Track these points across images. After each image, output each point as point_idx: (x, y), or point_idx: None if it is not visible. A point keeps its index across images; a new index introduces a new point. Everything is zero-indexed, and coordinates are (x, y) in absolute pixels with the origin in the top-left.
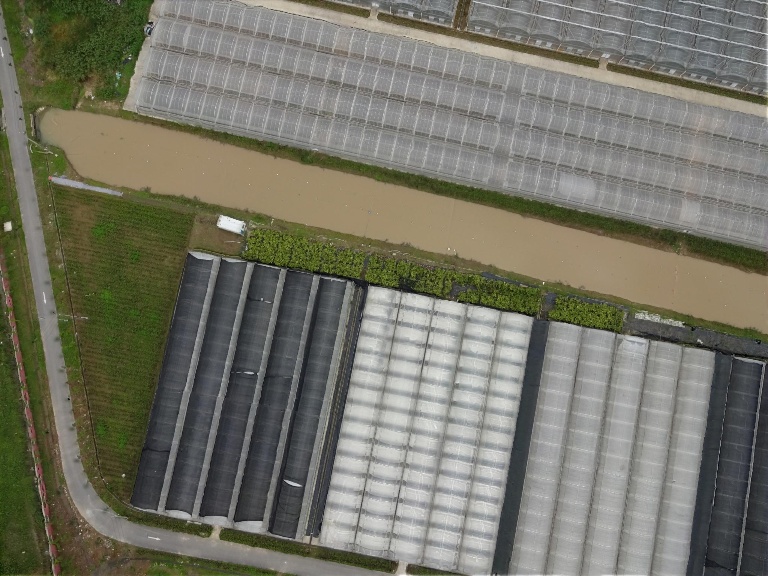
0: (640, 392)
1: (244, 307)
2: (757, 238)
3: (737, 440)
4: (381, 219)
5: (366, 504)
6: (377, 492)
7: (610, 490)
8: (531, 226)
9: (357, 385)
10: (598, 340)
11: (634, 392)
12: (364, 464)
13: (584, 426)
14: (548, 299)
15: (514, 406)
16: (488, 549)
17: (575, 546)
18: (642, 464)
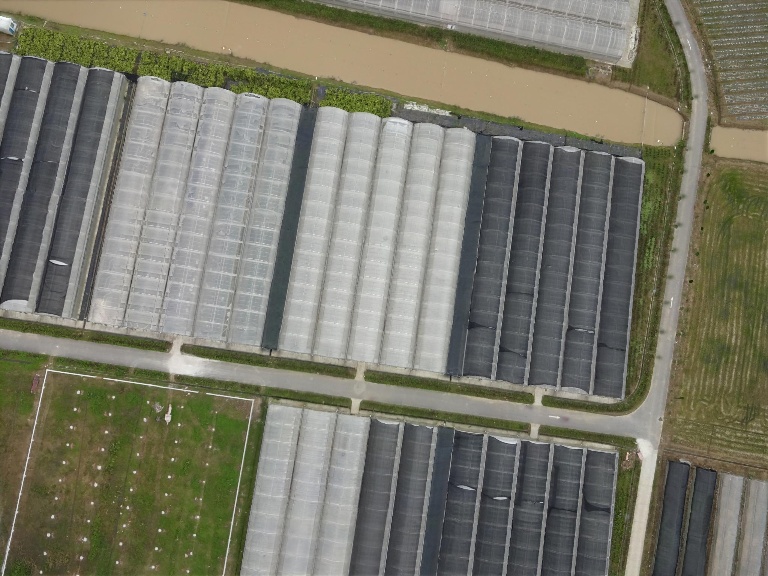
0: (405, 171)
1: (11, 99)
2: (512, 28)
3: (495, 210)
4: (156, 21)
5: (134, 281)
6: (144, 268)
7: (374, 259)
8: (304, 26)
9: (124, 168)
10: (362, 121)
11: (397, 169)
12: (132, 244)
13: (349, 201)
14: (319, 92)
15: (281, 185)
16: (256, 319)
17: (341, 312)
18: (406, 236)
